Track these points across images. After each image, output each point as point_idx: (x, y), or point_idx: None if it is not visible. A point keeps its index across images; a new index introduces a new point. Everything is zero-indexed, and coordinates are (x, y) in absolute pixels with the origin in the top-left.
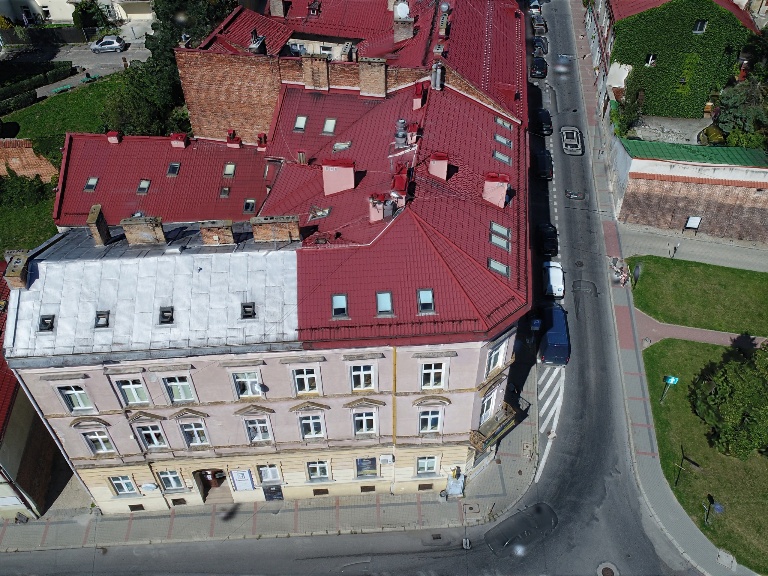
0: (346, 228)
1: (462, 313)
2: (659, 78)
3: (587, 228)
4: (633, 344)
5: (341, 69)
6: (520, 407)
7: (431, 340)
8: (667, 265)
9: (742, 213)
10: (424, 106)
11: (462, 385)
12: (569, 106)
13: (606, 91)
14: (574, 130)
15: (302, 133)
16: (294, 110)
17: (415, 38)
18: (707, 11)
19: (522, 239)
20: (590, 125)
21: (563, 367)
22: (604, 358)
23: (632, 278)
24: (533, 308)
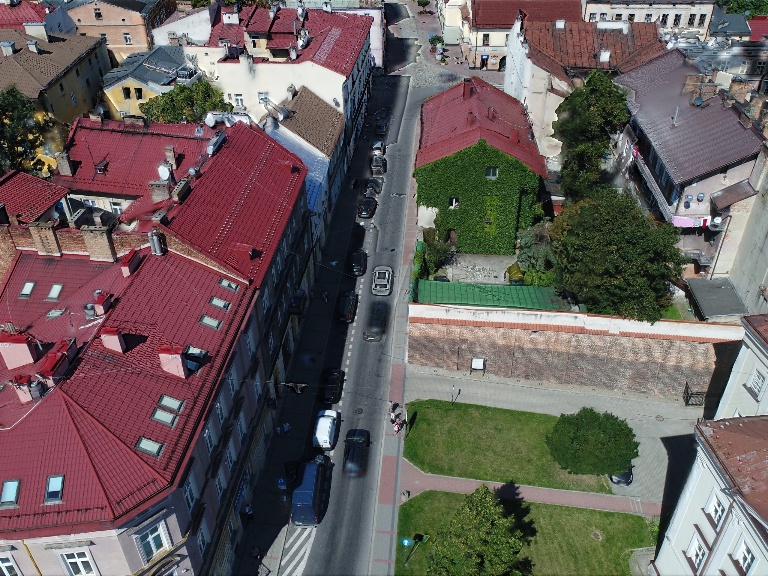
0: (4, 408)
1: (90, 501)
2: (465, 219)
3: (376, 372)
4: (392, 498)
5: (69, 236)
6: (258, 575)
7: (52, 532)
8: (446, 409)
9: (523, 354)
10: (134, 273)
11: (116, 572)
12: (388, 245)
13: (418, 232)
14: (387, 270)
15: (27, 299)
16: (24, 276)
17: (171, 199)
18: (495, 159)
19: (196, 411)
20: (404, 264)
21: (314, 527)
22: (360, 515)
23: (407, 425)
24: (291, 463)
